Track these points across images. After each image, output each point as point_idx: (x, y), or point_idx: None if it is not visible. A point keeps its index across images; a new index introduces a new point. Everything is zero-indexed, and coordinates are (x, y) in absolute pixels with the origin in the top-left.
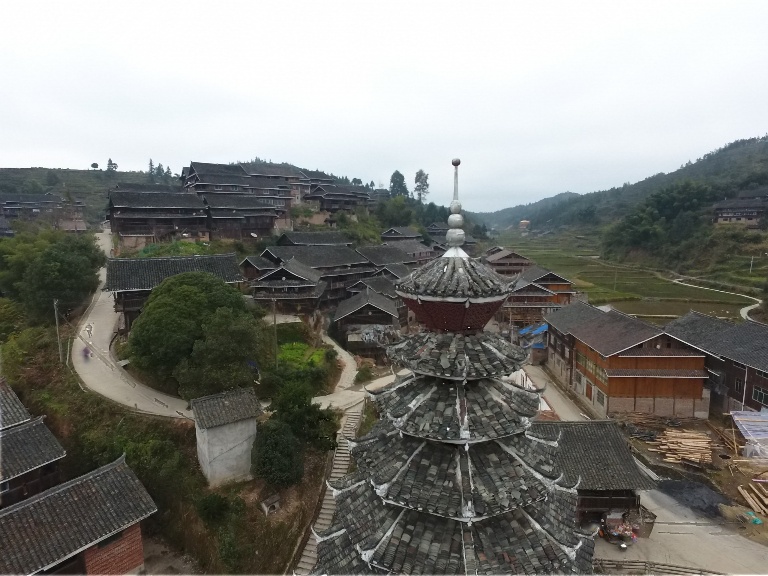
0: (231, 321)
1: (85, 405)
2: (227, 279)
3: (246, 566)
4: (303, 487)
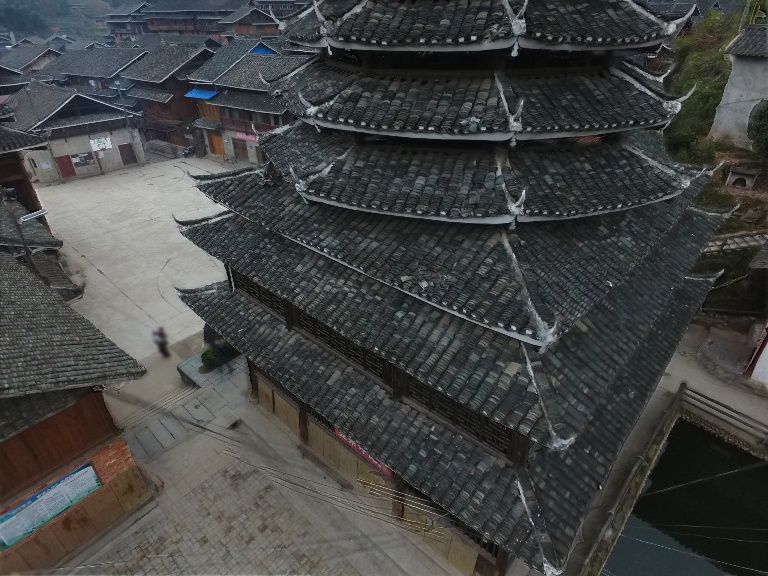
0: None
1: None
2: None
3: None
4: None
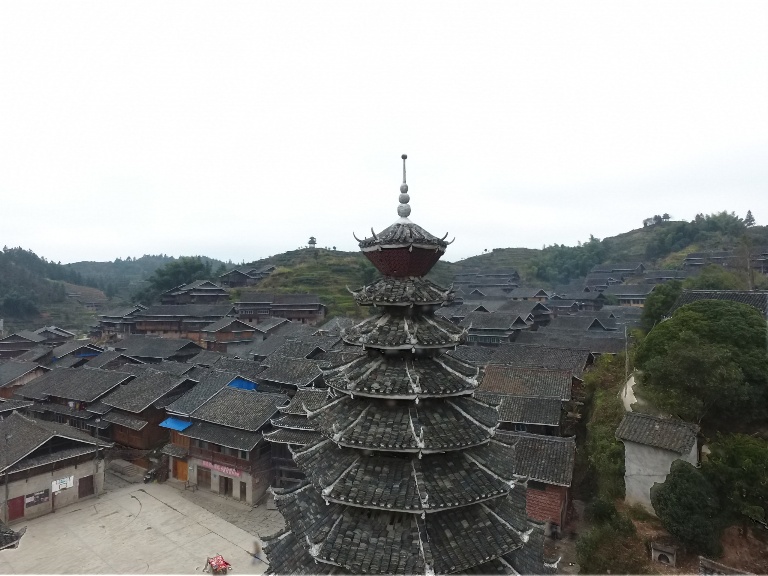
0: (688, 346)
1: None
2: None
3: (592, 572)
4: None
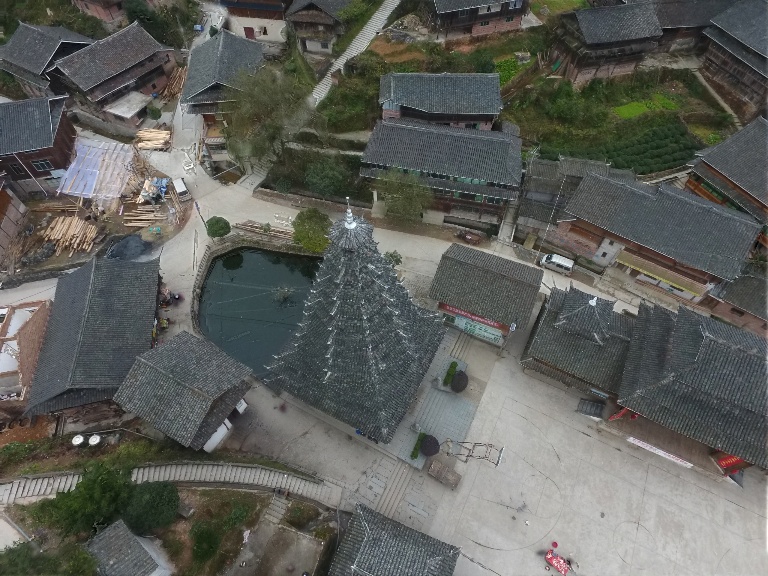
0: (7, 575)
1: None
2: None
3: None
4: None
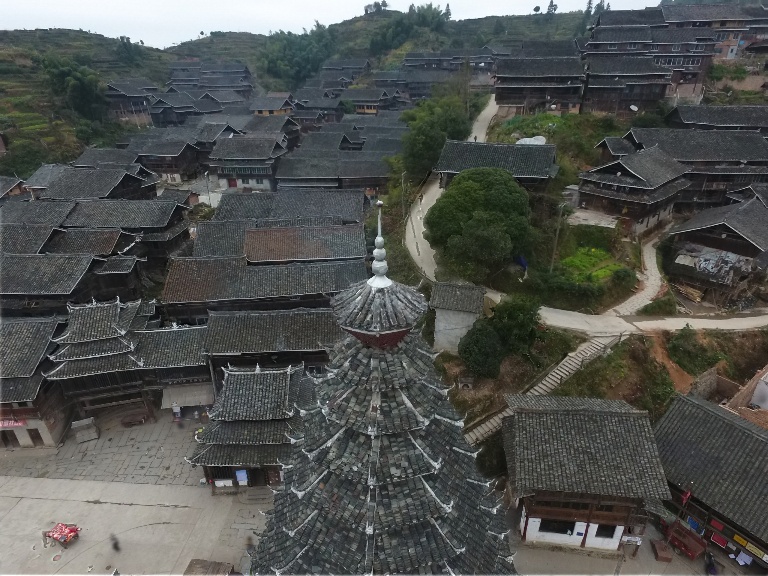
0: (481, 226)
1: (399, 256)
2: (534, 173)
3: None
4: (503, 384)
